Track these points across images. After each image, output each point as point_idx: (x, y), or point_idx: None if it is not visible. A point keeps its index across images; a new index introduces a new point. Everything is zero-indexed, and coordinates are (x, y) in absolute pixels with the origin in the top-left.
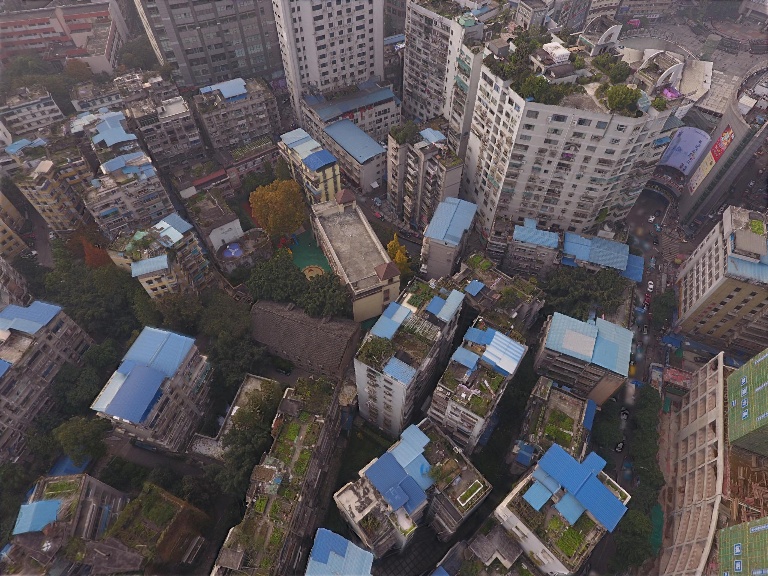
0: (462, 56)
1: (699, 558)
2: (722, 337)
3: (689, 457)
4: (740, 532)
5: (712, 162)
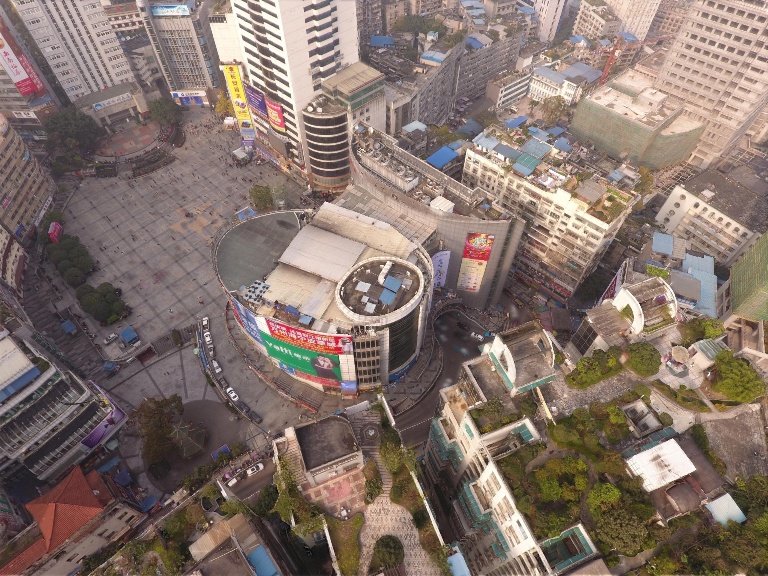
0: None
1: None
2: None
3: None
4: None
5: (482, 263)
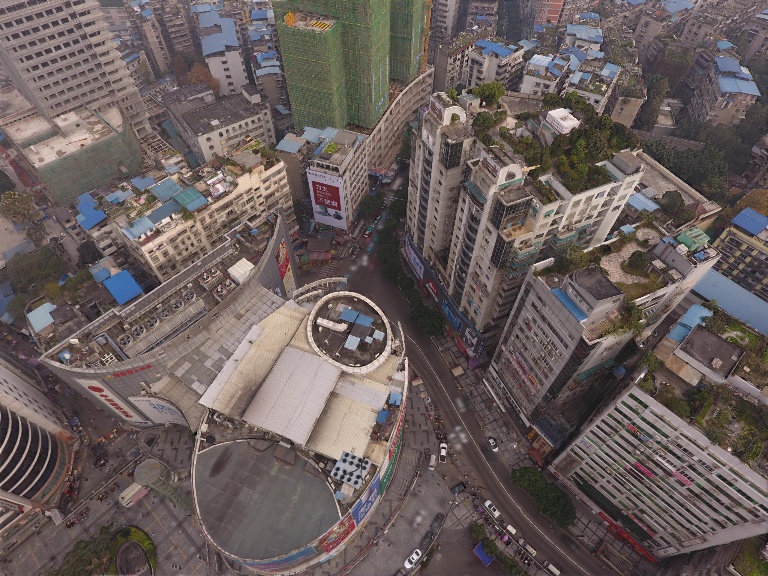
0: None
1: None
2: None
3: None
4: None
5: None
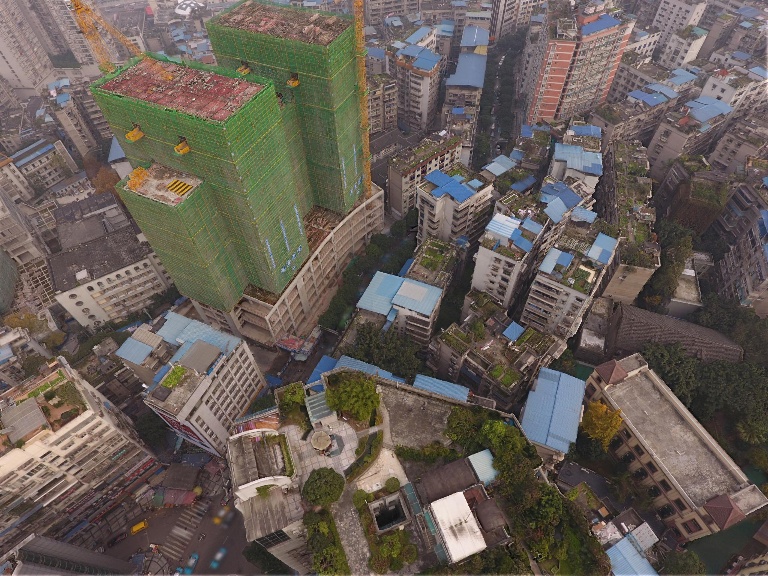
0: None
1: None
2: None
3: None
4: None
5: None
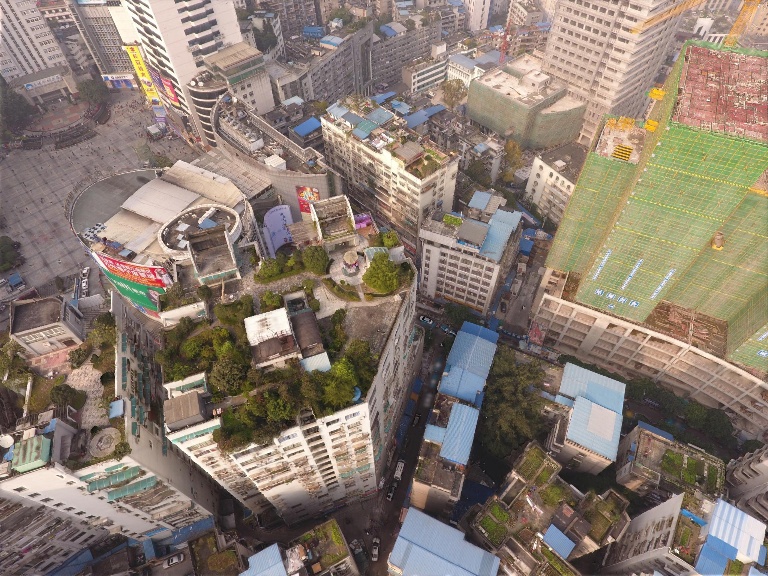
0: (93, 478)
1: (732, 378)
2: (497, 286)
3: (617, 352)
4: (751, 347)
5: None
